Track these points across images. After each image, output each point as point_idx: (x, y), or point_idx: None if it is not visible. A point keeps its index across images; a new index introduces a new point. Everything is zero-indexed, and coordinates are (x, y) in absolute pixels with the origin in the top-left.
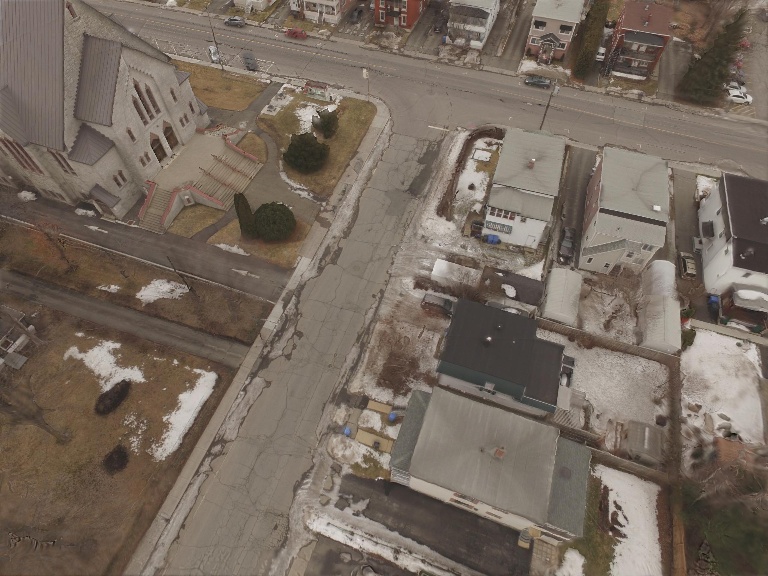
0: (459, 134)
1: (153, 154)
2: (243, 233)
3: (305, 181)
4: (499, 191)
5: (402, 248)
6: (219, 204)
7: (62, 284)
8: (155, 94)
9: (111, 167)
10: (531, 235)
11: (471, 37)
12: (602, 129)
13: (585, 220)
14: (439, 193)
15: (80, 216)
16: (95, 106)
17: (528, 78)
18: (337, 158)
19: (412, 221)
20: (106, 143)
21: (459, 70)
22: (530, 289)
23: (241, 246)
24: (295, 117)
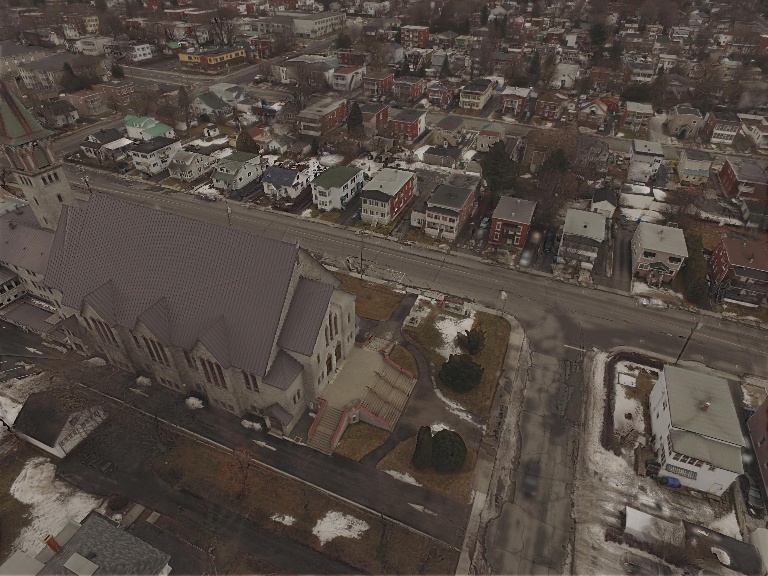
0: (597, 355)
1: (326, 372)
2: (418, 462)
3: (461, 400)
4: (680, 435)
5: (578, 486)
6: (386, 425)
7: (235, 511)
8: (338, 320)
9: (294, 388)
10: (718, 483)
11: (580, 258)
12: (735, 357)
13: (764, 465)
14: (597, 421)
15: (247, 429)
16: (299, 337)
17: (645, 300)
18: (486, 376)
19: (579, 453)
20: (297, 367)
21: (576, 288)
22: (745, 556)
23: (412, 474)
24: (436, 330)
